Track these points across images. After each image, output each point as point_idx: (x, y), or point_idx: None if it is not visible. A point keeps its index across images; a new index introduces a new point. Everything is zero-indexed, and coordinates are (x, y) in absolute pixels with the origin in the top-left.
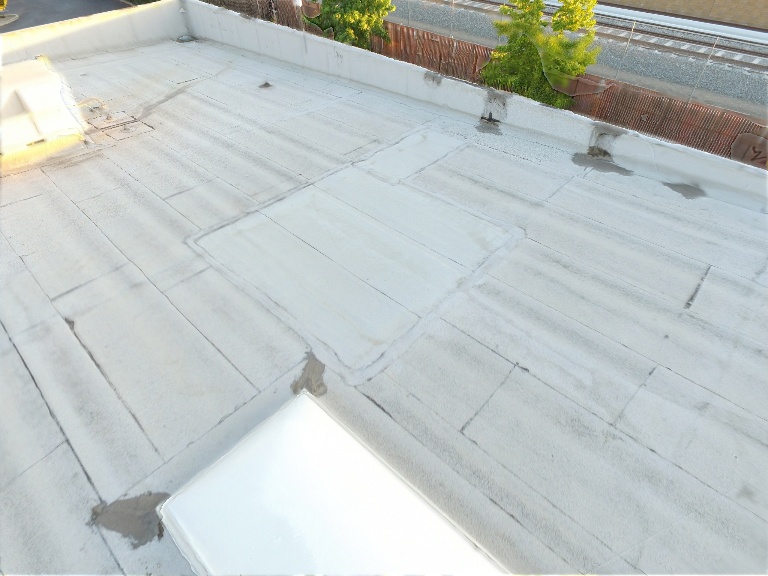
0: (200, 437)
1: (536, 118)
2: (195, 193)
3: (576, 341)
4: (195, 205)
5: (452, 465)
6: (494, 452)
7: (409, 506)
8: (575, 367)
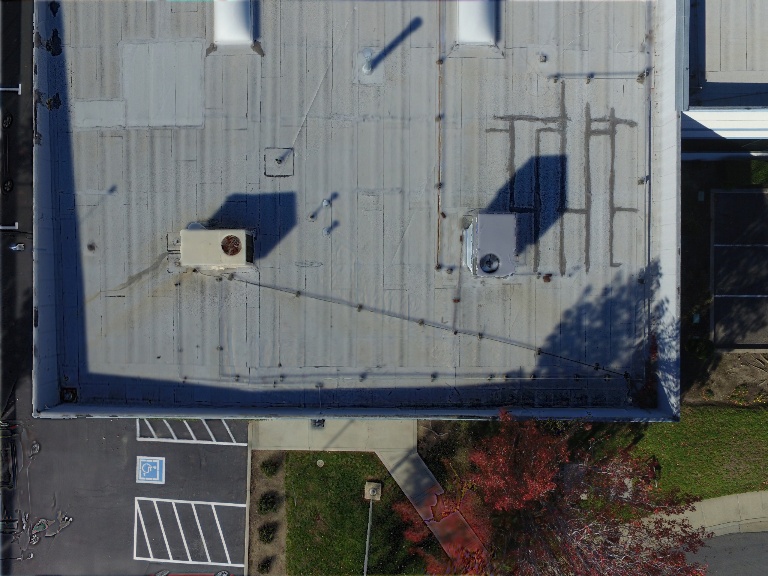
0: (240, 55)
1: (43, 77)
2: (185, 156)
3: (154, 5)
4: (190, 147)
5: (205, 8)
6: (196, 3)
7: (217, 3)
8: (162, 1)
